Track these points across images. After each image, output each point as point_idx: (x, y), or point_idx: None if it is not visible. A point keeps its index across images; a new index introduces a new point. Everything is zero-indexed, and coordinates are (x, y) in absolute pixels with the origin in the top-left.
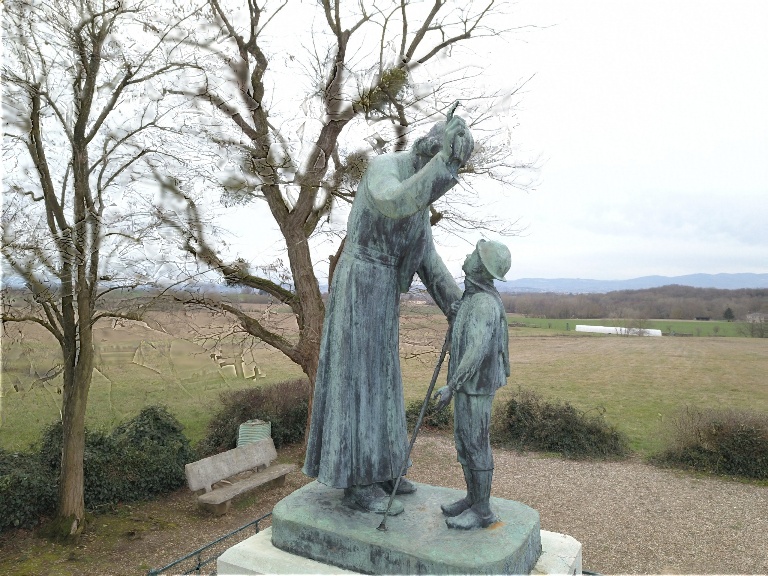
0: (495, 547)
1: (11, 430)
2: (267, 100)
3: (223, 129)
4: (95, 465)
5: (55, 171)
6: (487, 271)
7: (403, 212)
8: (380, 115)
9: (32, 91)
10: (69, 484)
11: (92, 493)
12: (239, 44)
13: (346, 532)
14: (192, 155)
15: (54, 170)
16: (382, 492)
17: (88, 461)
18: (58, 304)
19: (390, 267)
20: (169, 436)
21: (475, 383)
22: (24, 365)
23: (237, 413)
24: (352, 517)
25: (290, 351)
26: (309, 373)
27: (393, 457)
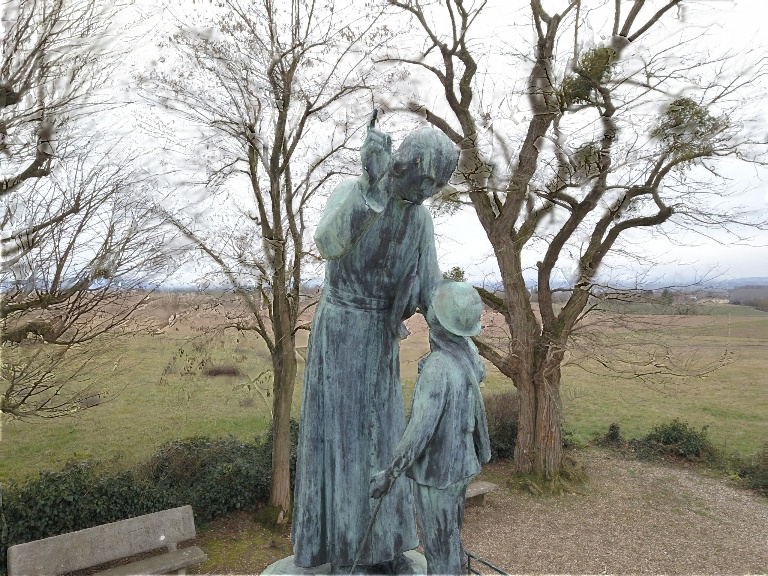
0: None
1: (244, 423)
2: (475, 104)
3: None
4: None
5: (269, 198)
6: (442, 323)
7: (330, 253)
8: (584, 103)
9: (233, 132)
10: (277, 478)
11: None
12: (443, 52)
13: None
14: None
15: (268, 197)
16: None
17: None
18: None
19: (370, 311)
20: None
21: (423, 470)
22: None
23: None
24: None
25: (499, 363)
26: (517, 388)
27: (375, 538)
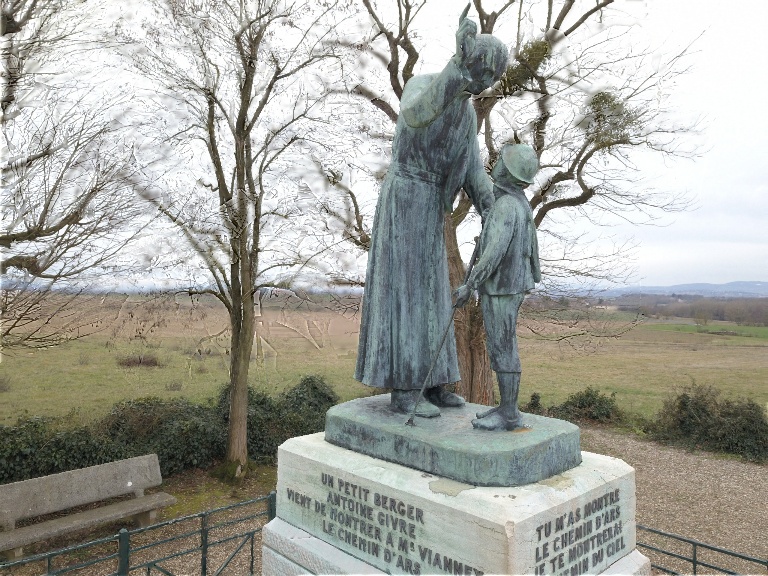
0: (508, 442)
1: (195, 387)
2: None
3: (366, 116)
4: (258, 421)
5: (227, 164)
6: (510, 173)
7: (422, 118)
8: None
9: (202, 92)
10: (235, 433)
11: (256, 445)
12: (389, 39)
13: (377, 425)
14: (337, 141)
15: (226, 163)
16: (422, 398)
17: (252, 416)
18: (230, 279)
19: (430, 184)
20: (325, 405)
21: (496, 283)
22: (207, 334)
23: (390, 391)
24: (390, 417)
25: None
26: None
27: None
